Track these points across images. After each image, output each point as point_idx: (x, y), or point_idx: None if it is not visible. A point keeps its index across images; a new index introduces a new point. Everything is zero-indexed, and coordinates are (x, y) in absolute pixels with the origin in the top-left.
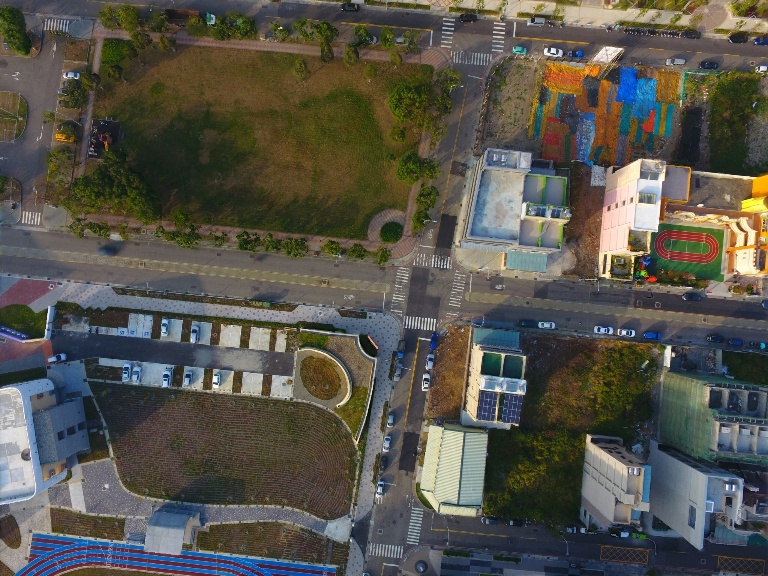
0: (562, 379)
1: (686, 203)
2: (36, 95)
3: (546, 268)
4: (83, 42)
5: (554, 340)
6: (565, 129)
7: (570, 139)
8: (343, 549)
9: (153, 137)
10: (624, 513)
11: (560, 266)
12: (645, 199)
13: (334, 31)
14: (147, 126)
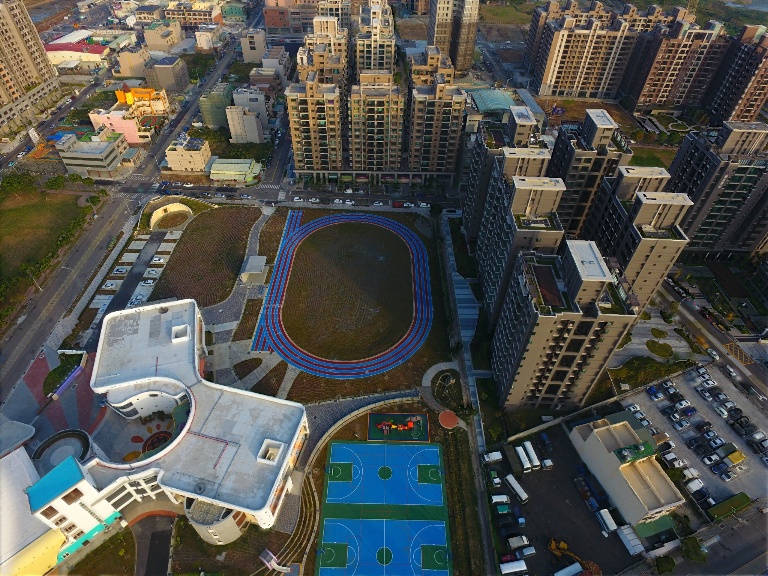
0: None
1: None
2: None
3: None
4: None
5: None
6: None
7: None
8: None
9: None
10: None
11: (141, 151)
12: None
13: None
14: None
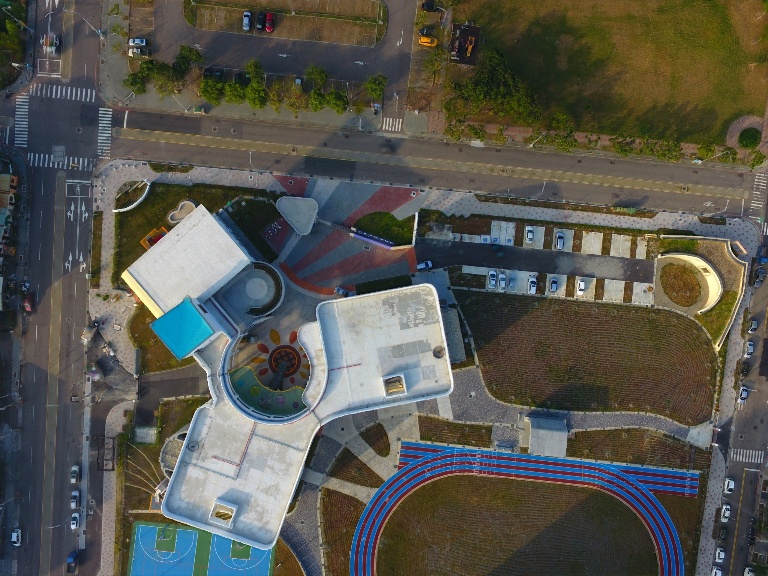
0: None
1: None
2: None
3: None
4: None
5: None
6: None
7: None
8: (705, 455)
9: (513, 42)
10: None
11: None
12: None
13: None
14: (507, 31)
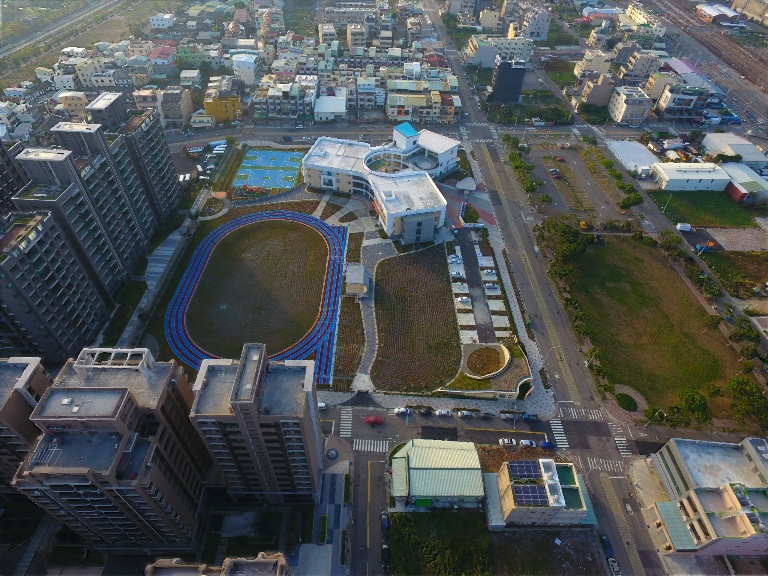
0: None
1: None
2: (599, 214)
3: (677, 560)
4: (642, 229)
5: None
6: None
7: None
8: (346, 388)
9: (608, 260)
10: None
11: None
12: None
13: (757, 341)
14: (612, 257)
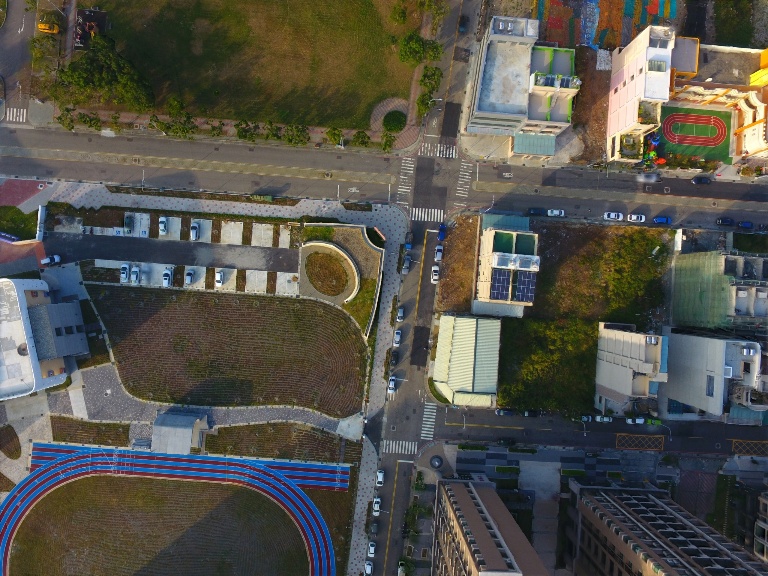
0: (573, 268)
1: (694, 78)
2: None
3: (554, 154)
4: None
5: (564, 228)
6: (569, 12)
7: (574, 22)
8: (356, 447)
9: (142, 27)
10: (642, 387)
11: (568, 152)
12: (655, 67)
13: None
14: (135, 16)
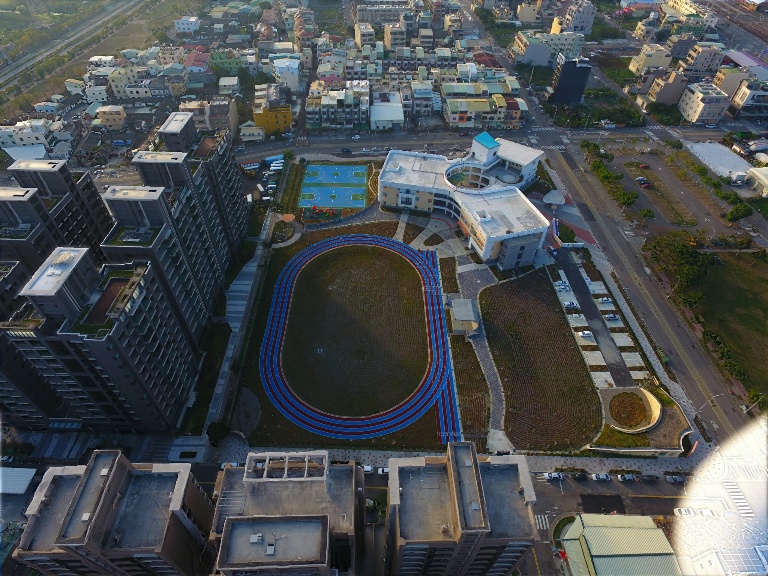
0: None
1: None
2: None
3: None
4: (755, 244)
5: None
6: None
7: None
8: (482, 448)
9: (729, 281)
10: None
11: None
12: None
13: None
14: (733, 278)
